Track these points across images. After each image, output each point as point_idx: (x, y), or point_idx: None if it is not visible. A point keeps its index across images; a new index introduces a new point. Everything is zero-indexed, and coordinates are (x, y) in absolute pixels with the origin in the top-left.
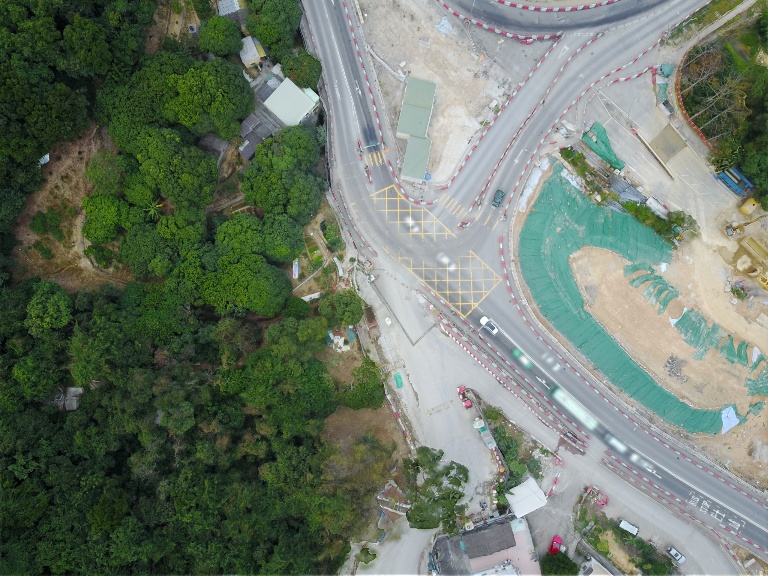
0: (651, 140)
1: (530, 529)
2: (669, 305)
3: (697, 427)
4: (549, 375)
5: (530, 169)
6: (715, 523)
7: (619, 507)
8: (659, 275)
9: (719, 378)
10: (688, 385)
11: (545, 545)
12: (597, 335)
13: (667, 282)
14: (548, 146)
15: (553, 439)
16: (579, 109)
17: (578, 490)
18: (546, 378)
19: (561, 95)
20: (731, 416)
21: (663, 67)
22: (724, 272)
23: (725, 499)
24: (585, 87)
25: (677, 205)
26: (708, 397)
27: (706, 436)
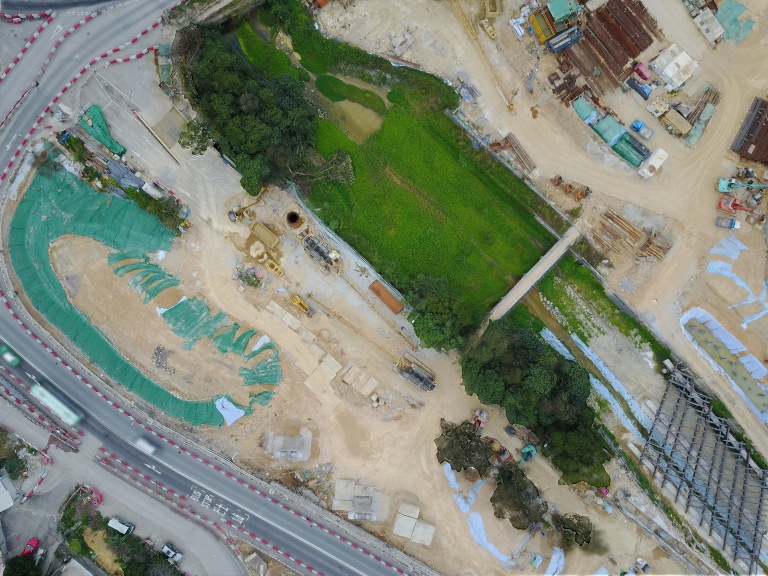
0: (155, 123)
1: (5, 533)
2: (161, 294)
3: (197, 419)
4: (40, 370)
5: (21, 155)
6: (217, 518)
7: (115, 505)
8: (155, 263)
9: (209, 368)
10: (177, 376)
11: (20, 549)
12: (84, 327)
13: (164, 270)
14: (44, 131)
15: (43, 437)
16: (76, 92)
17: (68, 489)
18: (37, 373)
19: (56, 77)
20: (229, 407)
21: (159, 47)
22: (234, 259)
23: (228, 492)
24: (80, 69)
25: (185, 191)
26: (199, 388)
27: (212, 428)
